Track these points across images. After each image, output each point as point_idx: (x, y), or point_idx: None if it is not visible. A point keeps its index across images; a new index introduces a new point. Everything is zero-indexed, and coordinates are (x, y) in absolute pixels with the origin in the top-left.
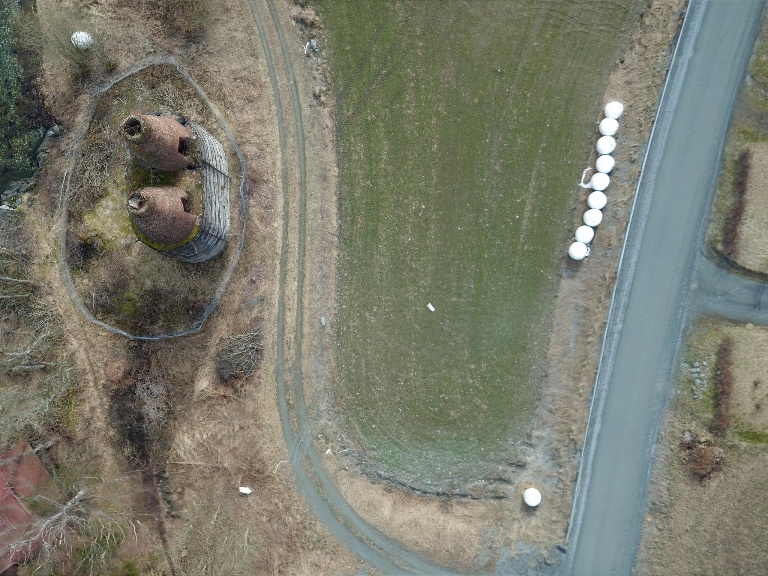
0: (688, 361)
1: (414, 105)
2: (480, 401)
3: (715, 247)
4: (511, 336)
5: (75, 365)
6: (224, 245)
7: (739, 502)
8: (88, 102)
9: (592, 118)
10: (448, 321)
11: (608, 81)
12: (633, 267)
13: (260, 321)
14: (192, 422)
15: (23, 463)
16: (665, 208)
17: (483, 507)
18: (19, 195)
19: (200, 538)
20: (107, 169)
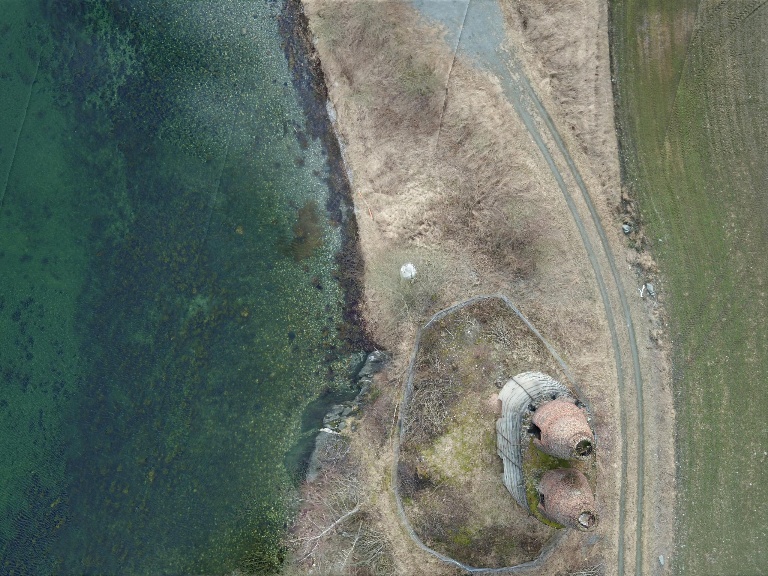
0: None
1: (756, 353)
2: None
3: None
4: None
5: None
6: None
7: None
8: (412, 330)
9: None
10: None
11: None
12: None
13: (599, 559)
14: None
15: None
16: None
17: None
18: (342, 419)
19: None
20: (444, 406)
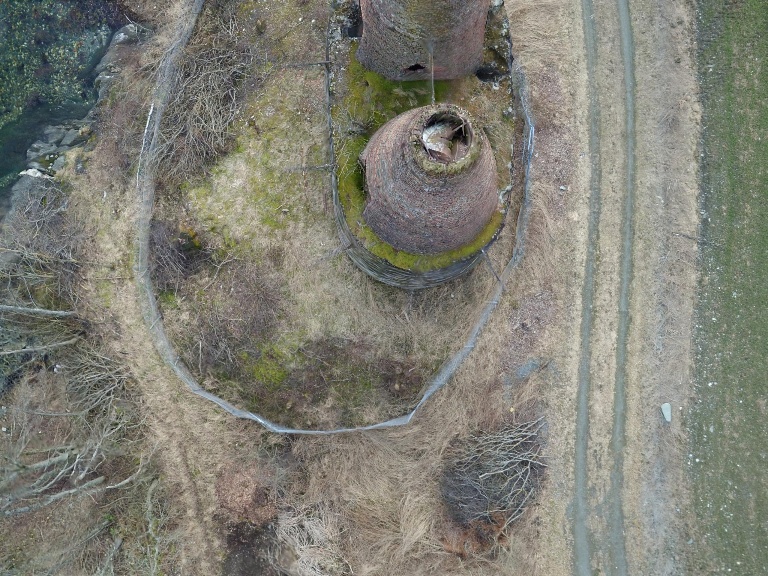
0: None
1: None
2: None
3: None
4: None
5: (161, 476)
6: None
7: None
8: None
9: None
10: None
11: None
12: None
13: (538, 409)
14: None
15: None
16: None
17: None
18: (60, 151)
19: None
20: (235, 100)
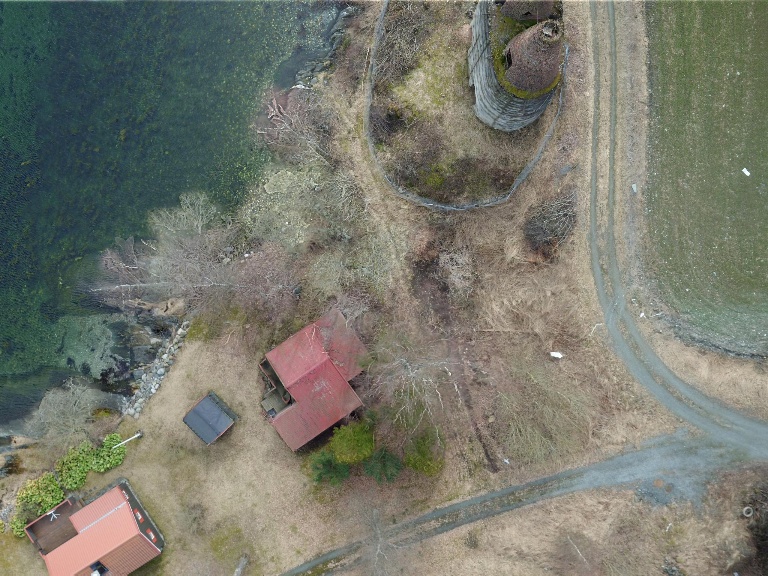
0: None
1: None
2: None
3: None
4: None
5: (378, 237)
6: None
7: None
8: None
9: None
10: (764, 185)
11: None
12: None
13: (572, 189)
14: (500, 290)
15: (336, 330)
16: None
17: None
18: (314, 75)
19: (507, 404)
20: (416, 42)
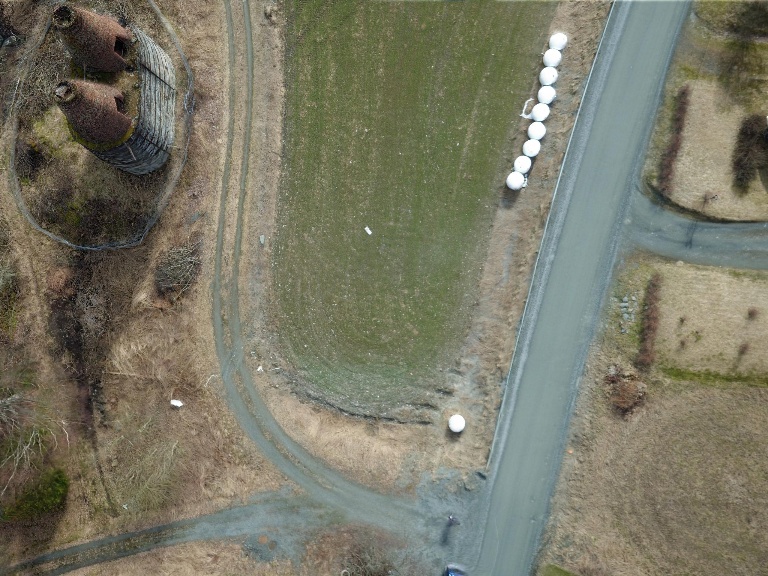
0: (617, 295)
1: (362, 28)
2: (411, 326)
3: (650, 183)
4: (445, 263)
5: (18, 272)
6: (167, 158)
7: (660, 438)
8: (46, 13)
9: (537, 49)
10: (384, 245)
11: (554, 13)
12: (568, 199)
13: (200, 236)
14: (129, 333)
15: None
16: (603, 141)
17: (409, 431)
18: None
19: (131, 449)
20: (58, 78)
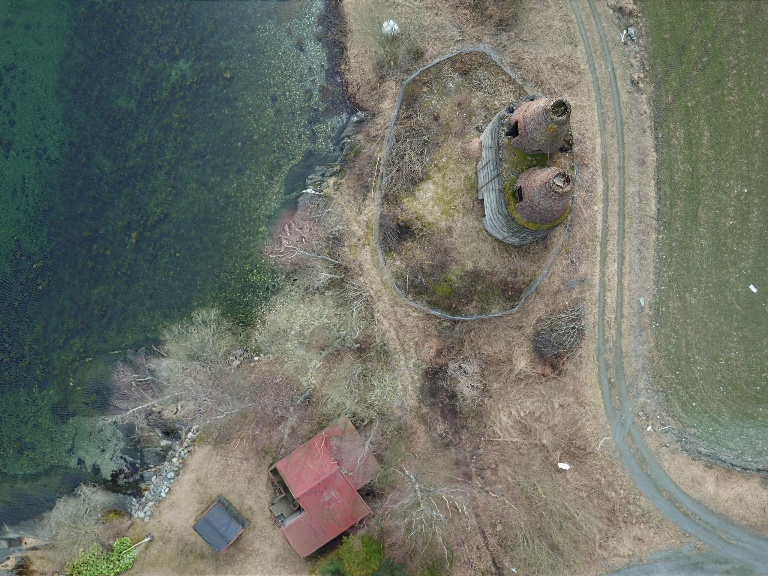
0: None
1: (736, 91)
2: None
3: None
4: None
5: (387, 344)
6: None
7: None
8: (394, 89)
9: None
10: None
11: None
12: None
13: (580, 302)
14: (508, 400)
15: (346, 439)
16: None
17: None
18: (324, 179)
19: None
20: (426, 154)
